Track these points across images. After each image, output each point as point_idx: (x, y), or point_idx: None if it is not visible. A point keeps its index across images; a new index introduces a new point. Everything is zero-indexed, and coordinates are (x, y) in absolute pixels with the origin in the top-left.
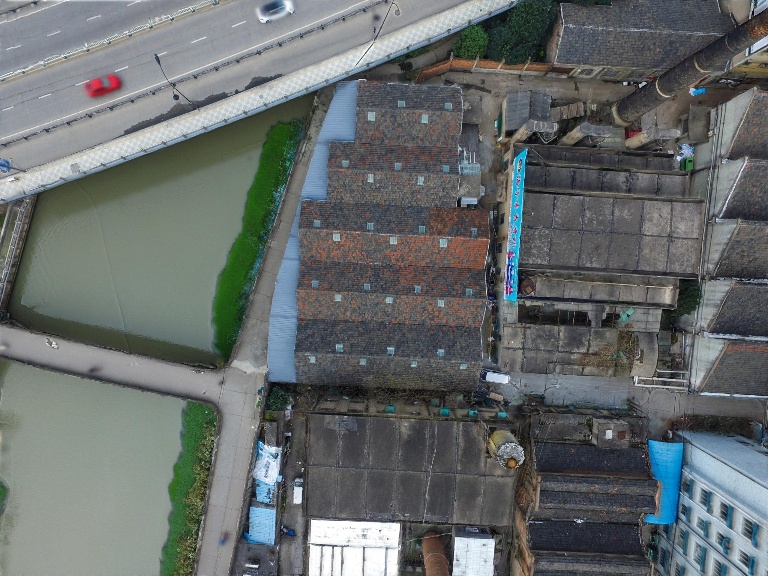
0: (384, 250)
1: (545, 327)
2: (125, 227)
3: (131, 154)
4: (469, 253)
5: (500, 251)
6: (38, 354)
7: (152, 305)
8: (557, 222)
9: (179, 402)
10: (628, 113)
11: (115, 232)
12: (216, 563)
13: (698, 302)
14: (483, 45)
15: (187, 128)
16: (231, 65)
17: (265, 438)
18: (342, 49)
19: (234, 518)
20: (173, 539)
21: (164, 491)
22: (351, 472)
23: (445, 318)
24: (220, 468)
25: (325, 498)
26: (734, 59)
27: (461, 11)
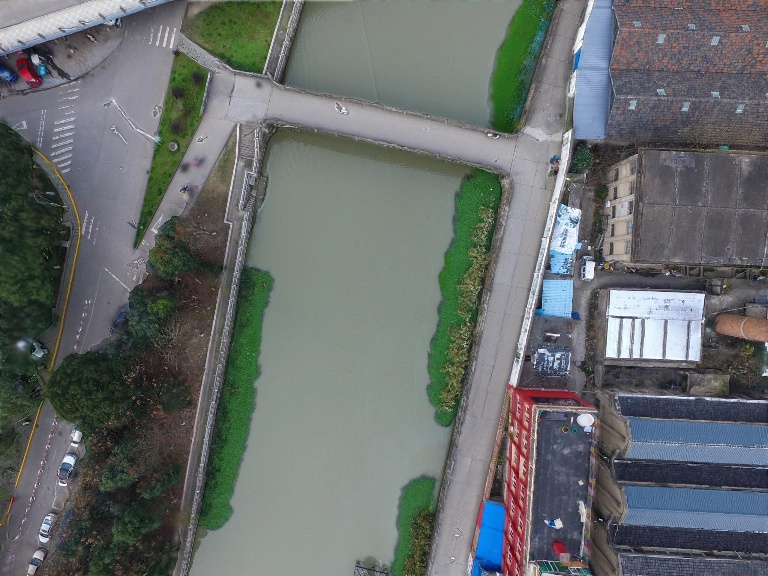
0: None
1: None
2: (392, 10)
3: None
4: None
5: None
6: (327, 120)
7: (415, 93)
8: None
9: (447, 189)
10: None
11: (378, 18)
12: (497, 347)
13: None
14: None
15: None
16: None
17: (568, 200)
18: None
19: (519, 298)
20: (443, 330)
21: (434, 280)
22: (688, 211)
23: (767, 64)
24: (507, 243)
25: (658, 241)
26: None
27: None
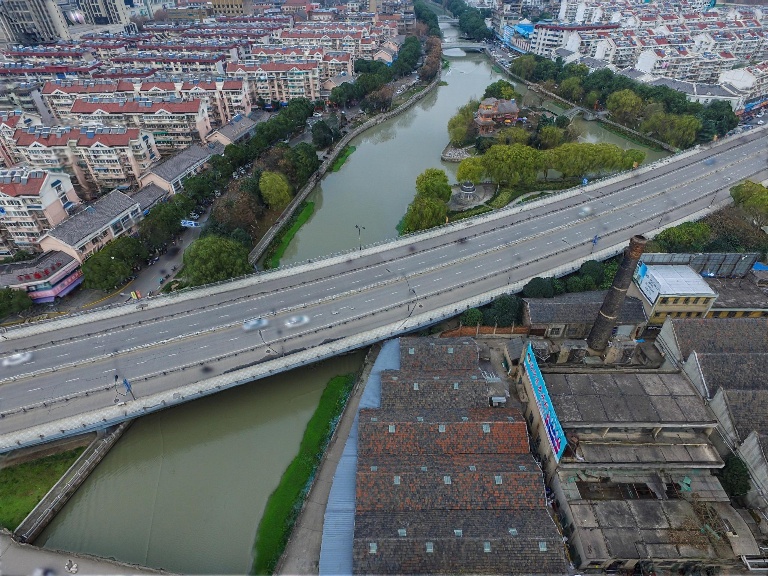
0: (435, 439)
1: (612, 502)
2: (186, 464)
3: (225, 385)
4: (511, 437)
5: (539, 443)
6: None
7: (187, 544)
8: (574, 390)
9: None
10: (595, 342)
11: (174, 471)
12: None
13: (746, 468)
14: (480, 316)
15: (273, 367)
16: (311, 334)
17: None
18: (387, 323)
19: None
20: None
21: None
22: None
23: (507, 499)
24: None
25: None
26: (647, 313)
27: (461, 304)
